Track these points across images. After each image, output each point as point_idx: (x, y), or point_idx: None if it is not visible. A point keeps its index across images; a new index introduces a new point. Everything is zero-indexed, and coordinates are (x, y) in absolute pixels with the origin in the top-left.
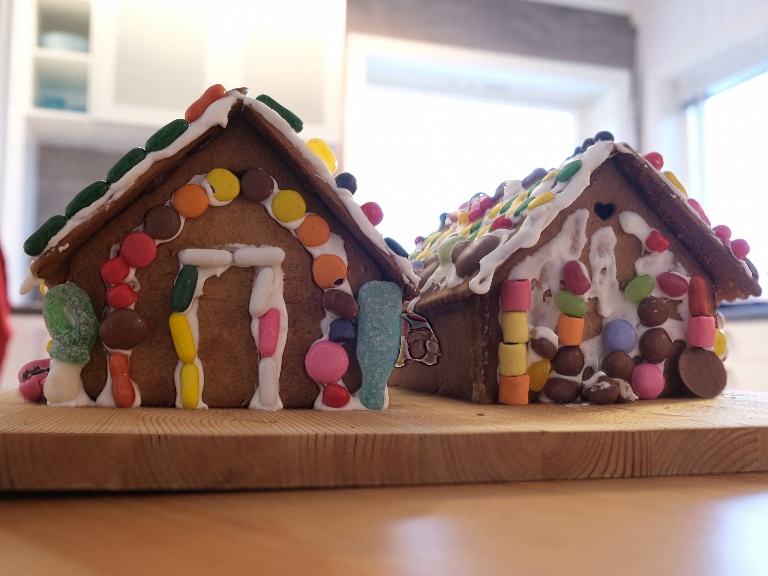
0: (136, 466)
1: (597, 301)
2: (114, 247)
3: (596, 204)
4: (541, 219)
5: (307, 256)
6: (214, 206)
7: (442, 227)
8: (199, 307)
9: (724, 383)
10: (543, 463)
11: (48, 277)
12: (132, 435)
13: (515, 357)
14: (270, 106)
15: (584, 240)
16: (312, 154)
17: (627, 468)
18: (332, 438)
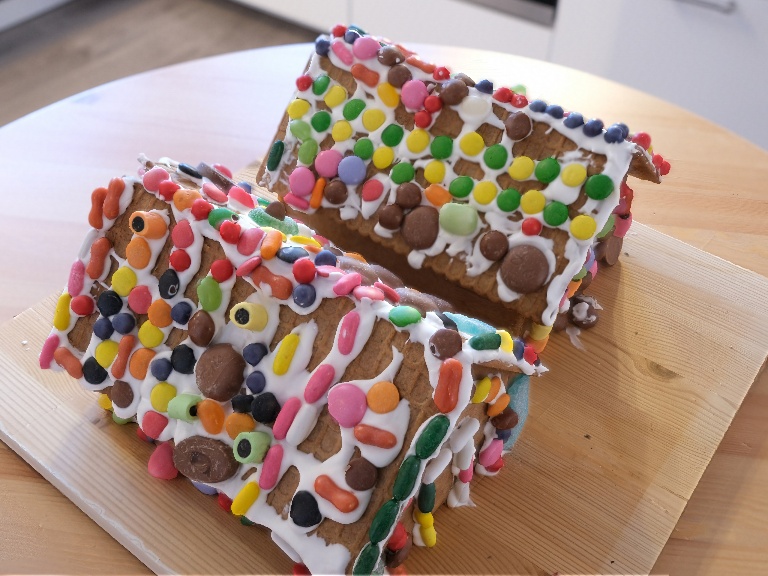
0: None
1: None
2: None
3: None
4: None
5: None
6: None
7: (324, 60)
8: None
9: None
10: None
11: None
12: None
13: None
14: None
15: None
16: (509, 357)
17: None
18: None
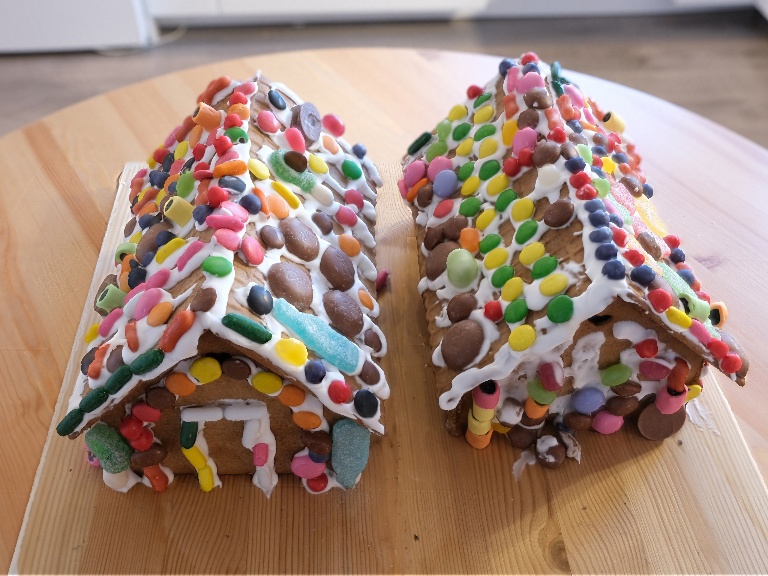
0: None
1: (573, 377)
2: (127, 406)
3: None
4: (516, 361)
5: None
6: None
7: (501, 80)
8: (204, 432)
9: (679, 428)
10: None
11: None
12: None
13: (478, 429)
14: (236, 330)
15: (569, 344)
16: (281, 364)
17: None
18: None
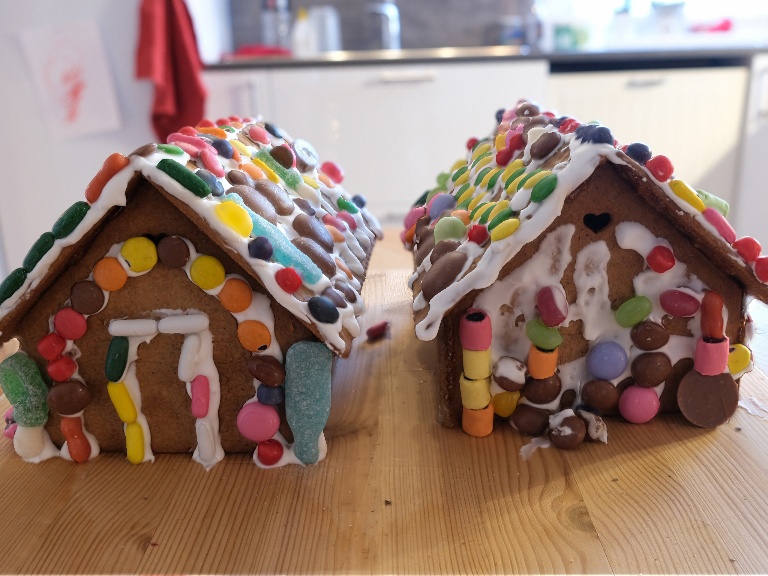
0: None
1: (582, 323)
2: (51, 319)
3: (586, 215)
4: (499, 256)
5: (233, 318)
6: (134, 276)
7: None
8: (137, 369)
9: (733, 409)
10: None
11: (7, 340)
12: None
13: (472, 394)
14: (171, 174)
15: (567, 259)
16: (219, 225)
17: None
18: None
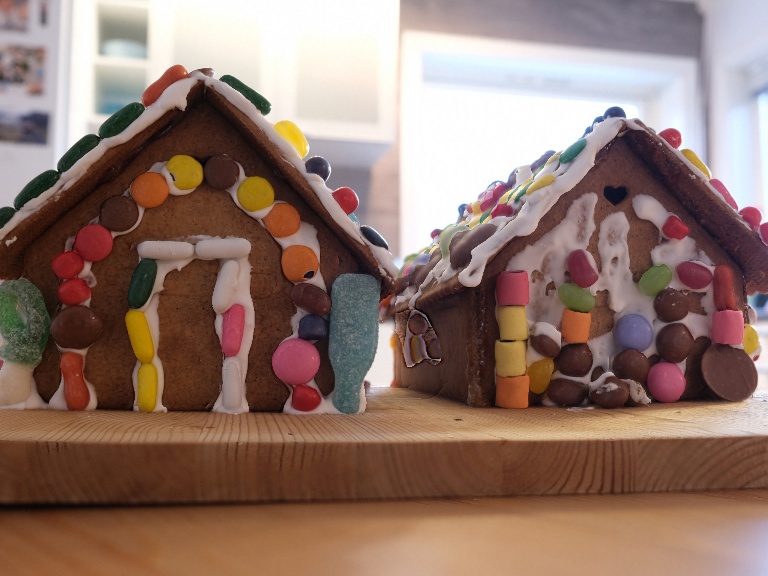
0: (31, 477)
1: (607, 294)
2: (69, 240)
3: (606, 187)
4: (539, 204)
5: (276, 247)
6: (175, 195)
7: (461, 219)
8: (159, 303)
9: (754, 384)
10: (504, 476)
11: (3, 273)
12: (26, 442)
13: (512, 356)
14: (234, 87)
15: (592, 227)
16: (279, 137)
17: (605, 483)
18: (255, 447)
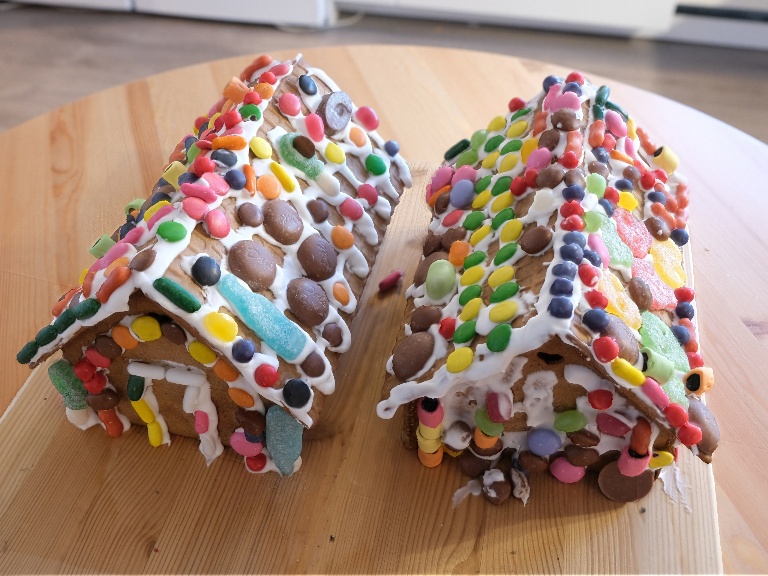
0: None
1: None
2: (83, 348)
3: None
4: (450, 382)
5: None
6: (144, 341)
7: (544, 97)
8: (153, 389)
9: (645, 494)
10: None
11: None
12: None
13: (423, 446)
14: (165, 294)
15: (518, 377)
16: (206, 336)
17: None
18: None
